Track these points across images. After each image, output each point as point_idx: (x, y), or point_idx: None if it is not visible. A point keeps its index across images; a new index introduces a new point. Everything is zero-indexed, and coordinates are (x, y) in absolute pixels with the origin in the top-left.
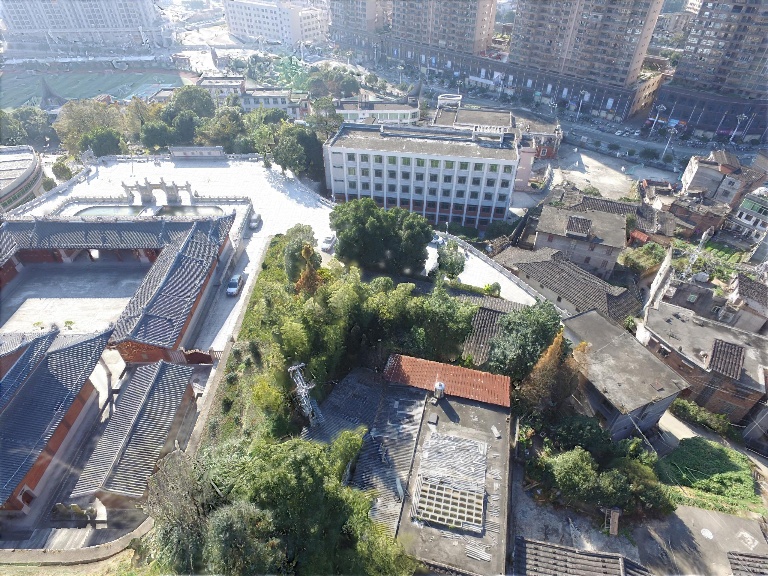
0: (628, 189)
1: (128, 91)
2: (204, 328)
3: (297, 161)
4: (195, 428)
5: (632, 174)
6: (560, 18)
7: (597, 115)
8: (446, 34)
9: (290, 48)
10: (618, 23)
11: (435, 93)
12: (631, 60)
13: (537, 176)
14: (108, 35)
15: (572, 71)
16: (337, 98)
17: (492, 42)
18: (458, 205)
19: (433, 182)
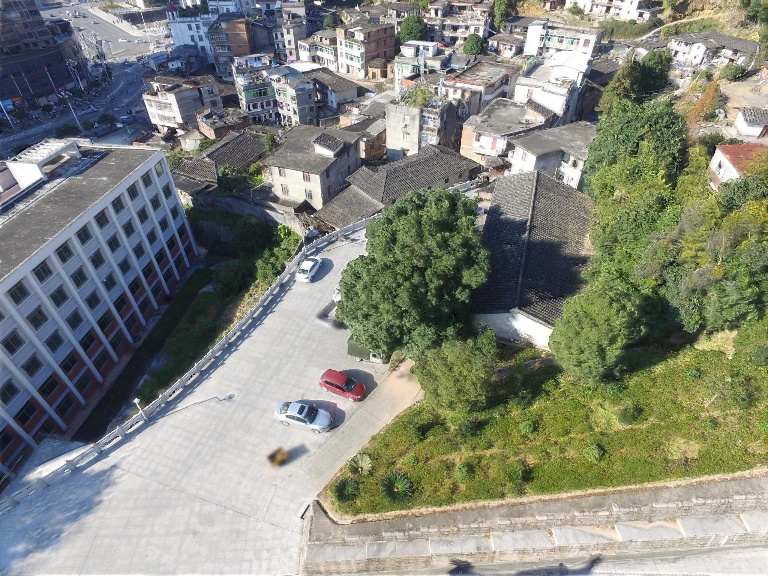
0: None
1: None
2: None
3: None
4: None
5: None
6: None
7: None
8: None
9: None
10: None
11: None
12: None
13: None
14: None
15: None
16: None
17: None
18: (145, 270)
19: (101, 267)
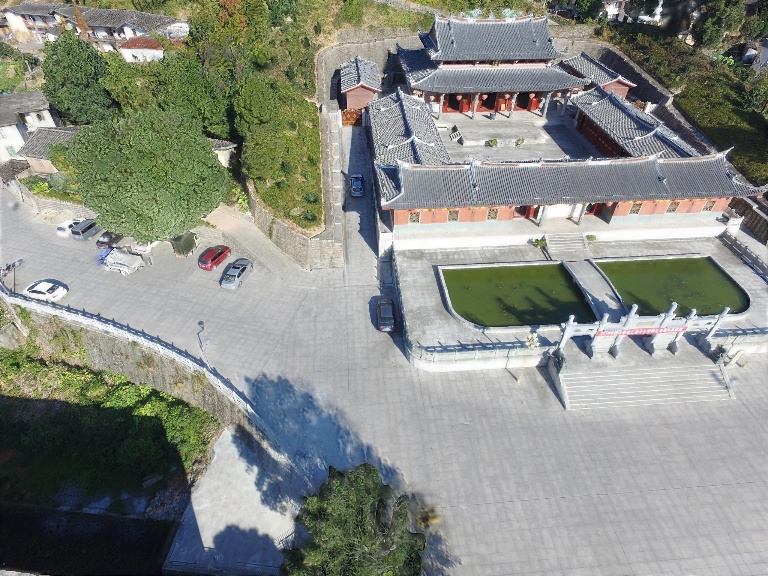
0: None
1: None
2: (367, 149)
3: None
4: (323, 71)
5: None
6: None
7: None
8: None
9: None
10: None
11: None
12: None
13: None
14: None
15: None
16: None
17: None
18: None
19: None
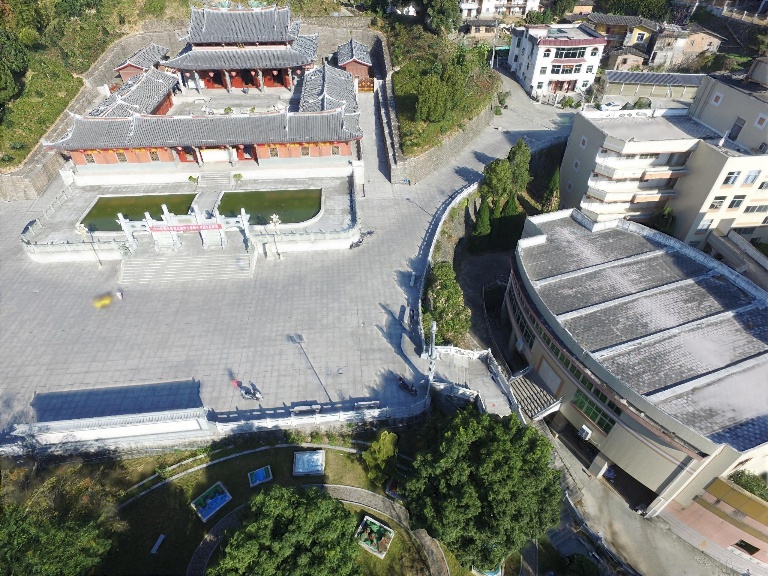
0: None
1: None
2: None
3: None
4: (111, 54)
5: None
6: None
7: None
8: None
9: None
10: None
11: None
12: None
13: None
14: None
15: None
16: None
17: None
18: None
19: None
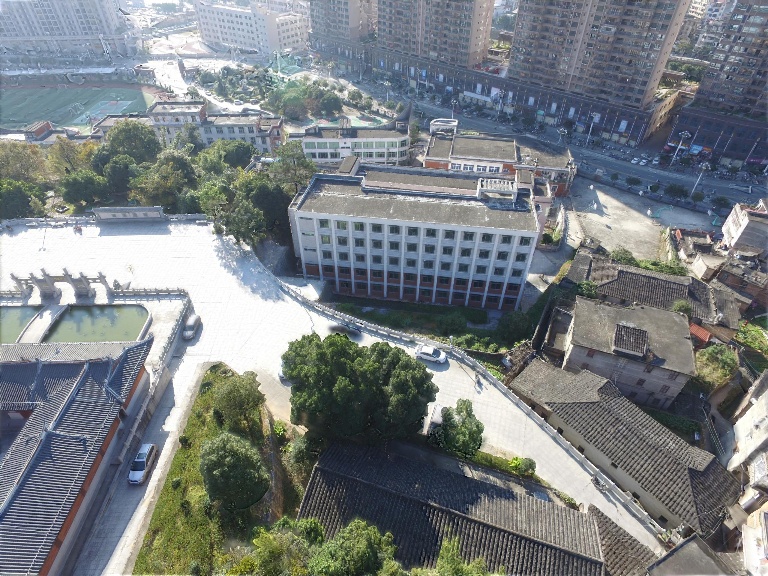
0: (657, 238)
1: (81, 110)
2: (79, 565)
3: (254, 230)
4: None
5: (658, 217)
6: (567, 30)
7: (608, 138)
8: (437, 45)
9: (266, 59)
10: (634, 37)
11: (427, 117)
12: (649, 79)
13: (548, 219)
14: (66, 43)
15: (580, 89)
16: (317, 118)
17: (488, 53)
18: (461, 280)
19: (429, 254)
